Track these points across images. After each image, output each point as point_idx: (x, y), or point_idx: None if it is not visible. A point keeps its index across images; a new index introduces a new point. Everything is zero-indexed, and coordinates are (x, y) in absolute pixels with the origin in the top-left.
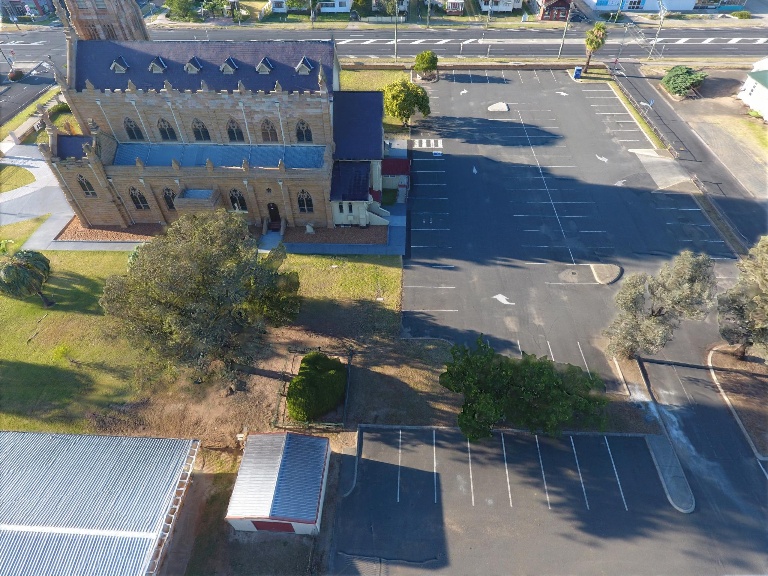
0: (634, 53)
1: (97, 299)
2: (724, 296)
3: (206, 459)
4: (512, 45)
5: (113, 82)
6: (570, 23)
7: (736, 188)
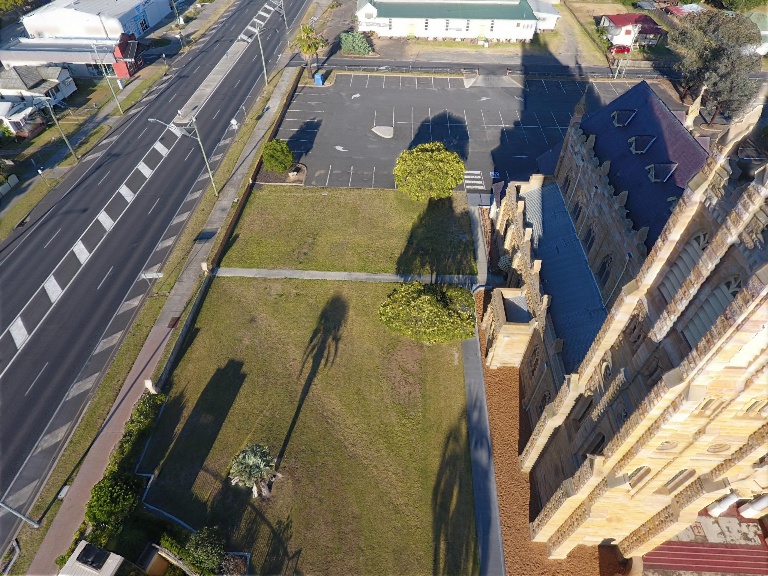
0: (271, 51)
1: None
2: (691, 72)
3: None
4: (210, 103)
5: None
6: (157, 64)
7: (512, 66)
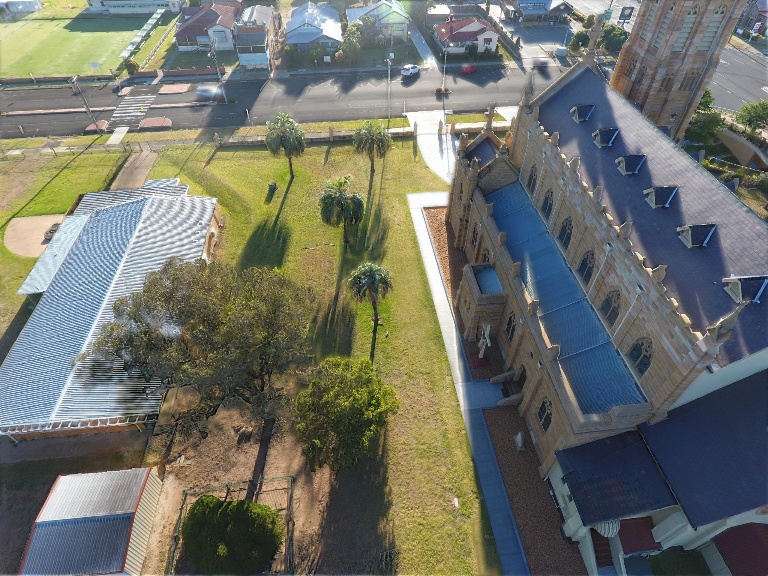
0: None
1: (356, 269)
2: None
3: (163, 435)
4: None
5: (561, 125)
6: None
7: None
